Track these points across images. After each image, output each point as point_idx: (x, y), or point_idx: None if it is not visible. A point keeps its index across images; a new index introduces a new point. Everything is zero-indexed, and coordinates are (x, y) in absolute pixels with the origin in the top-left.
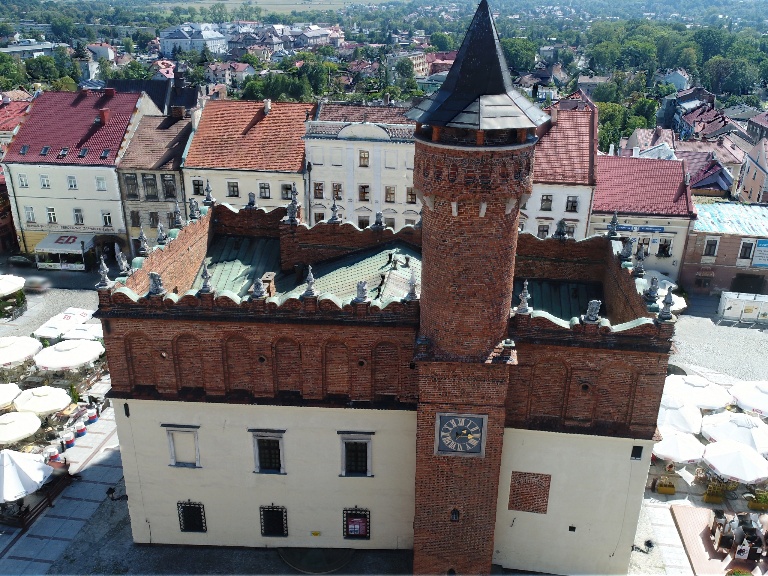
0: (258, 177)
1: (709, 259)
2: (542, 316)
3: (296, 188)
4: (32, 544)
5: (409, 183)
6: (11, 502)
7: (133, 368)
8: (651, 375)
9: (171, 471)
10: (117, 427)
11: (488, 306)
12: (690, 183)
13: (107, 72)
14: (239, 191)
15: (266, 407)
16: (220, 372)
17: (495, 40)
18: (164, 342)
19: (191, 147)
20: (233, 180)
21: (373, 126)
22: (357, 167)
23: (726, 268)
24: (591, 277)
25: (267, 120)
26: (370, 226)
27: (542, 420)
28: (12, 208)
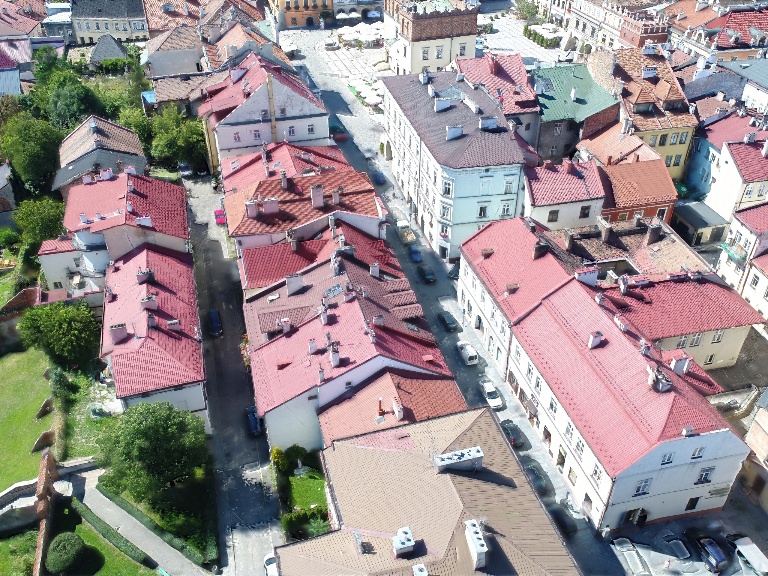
0: None
1: None
2: None
3: None
4: None
5: None
6: None
7: None
8: None
9: None
10: None
11: None
12: (23, 58)
13: None
14: None
15: None
16: None
17: None
18: None
19: None
20: None
21: None
22: None
23: None
24: None
25: None
26: (406, 0)
27: None
28: None
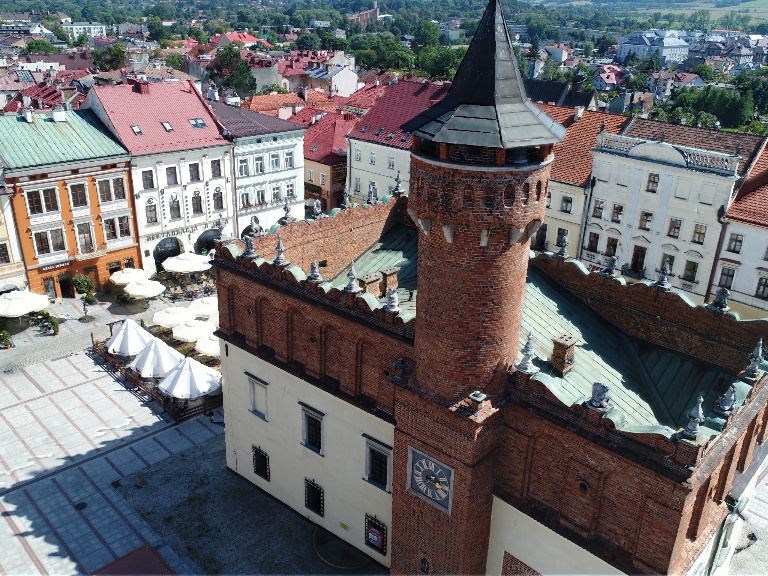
0: None
1: None
2: (541, 381)
3: (576, 202)
4: (173, 435)
5: (699, 219)
6: (181, 399)
7: (234, 316)
8: (662, 505)
9: (250, 415)
10: None
11: (458, 346)
12: None
13: (550, 72)
14: None
15: (311, 386)
16: (285, 340)
17: (497, 42)
18: (251, 299)
19: None
20: None
21: (669, 147)
22: (643, 191)
23: None
24: None
25: (573, 128)
26: None
27: (538, 506)
28: (347, 177)
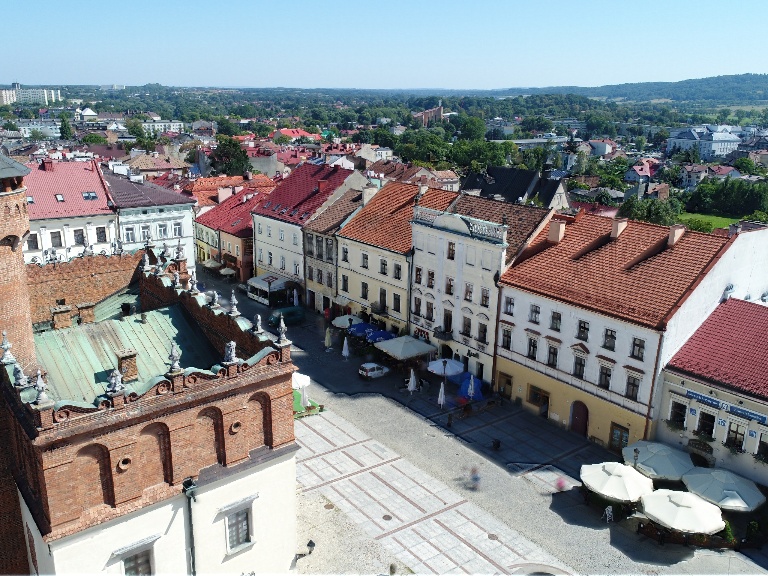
0: (380, 253)
1: None
2: (6, 368)
3: (404, 269)
4: None
5: (484, 284)
6: None
7: None
8: (39, 462)
9: None
10: None
11: None
12: None
13: (582, 165)
14: (368, 263)
15: None
16: None
17: None
18: None
19: (352, 219)
20: (365, 252)
21: (459, 218)
22: (446, 258)
23: None
24: None
25: None
26: None
27: (26, 477)
28: (253, 248)
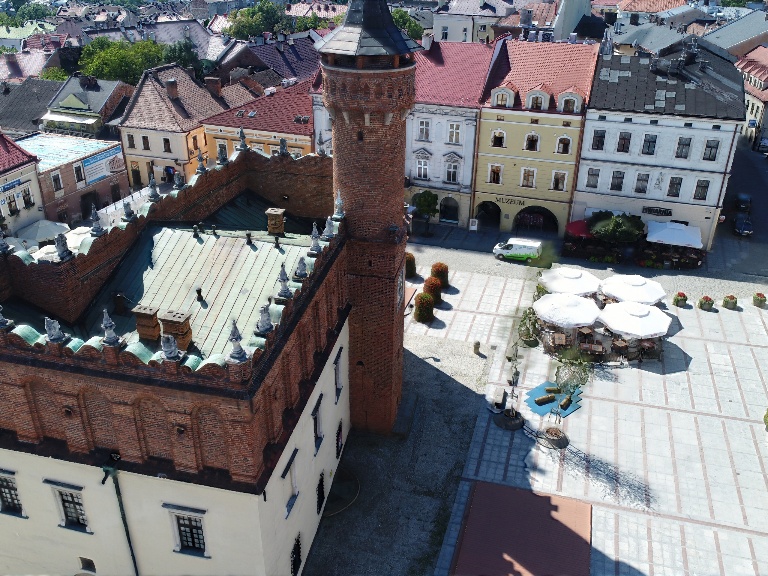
0: None
1: (60, 193)
2: None
3: None
4: None
5: None
6: None
7: None
8: None
9: None
10: (260, 526)
11: None
12: None
13: None
14: None
15: None
16: (296, 376)
17: None
18: None
19: None
20: None
21: None
22: None
23: (73, 195)
24: (243, 187)
25: None
26: None
27: None
28: None
